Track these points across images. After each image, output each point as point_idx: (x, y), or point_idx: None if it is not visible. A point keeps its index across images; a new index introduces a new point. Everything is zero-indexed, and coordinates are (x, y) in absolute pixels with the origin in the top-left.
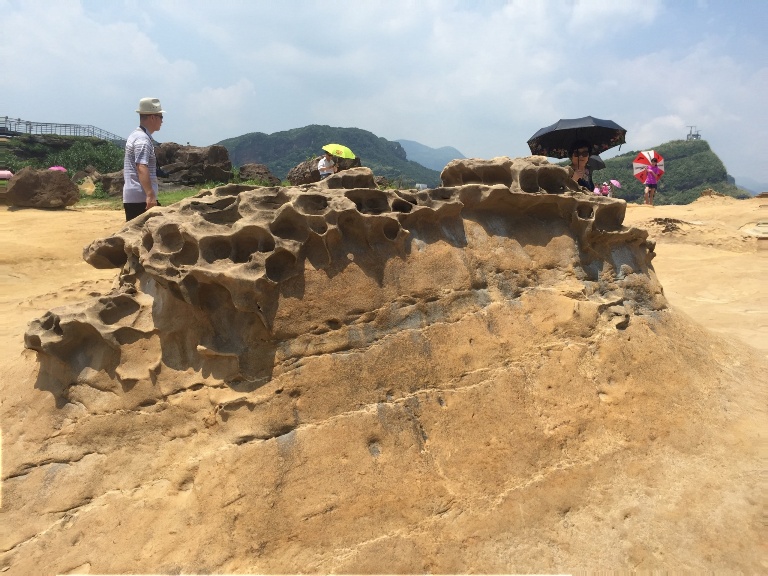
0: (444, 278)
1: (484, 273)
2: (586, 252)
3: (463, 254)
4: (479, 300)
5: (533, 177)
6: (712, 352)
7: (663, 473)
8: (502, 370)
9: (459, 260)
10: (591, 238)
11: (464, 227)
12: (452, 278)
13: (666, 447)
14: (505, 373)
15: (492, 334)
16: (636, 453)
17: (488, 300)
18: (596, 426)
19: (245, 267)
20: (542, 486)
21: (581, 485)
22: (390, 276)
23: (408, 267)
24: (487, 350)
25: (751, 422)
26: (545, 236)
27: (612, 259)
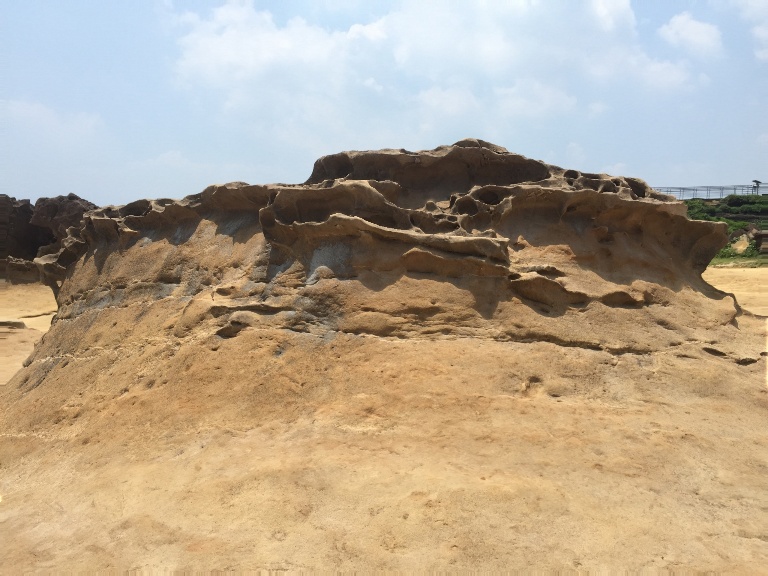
0: (141, 270)
1: (183, 269)
2: (278, 249)
3: (173, 251)
4: (160, 293)
5: (324, 169)
6: (339, 400)
7: (44, 471)
8: (108, 352)
9: (164, 256)
10: (284, 232)
11: (198, 227)
12: (147, 271)
13: (80, 453)
14: (106, 354)
15: (134, 322)
16: (64, 447)
17: (169, 294)
18: (86, 415)
19: (49, 256)
20: (13, 441)
21: (21, 452)
22: (107, 266)
23: (121, 260)
24: (114, 333)
25: (151, 469)
26: (253, 232)
27: (311, 259)
